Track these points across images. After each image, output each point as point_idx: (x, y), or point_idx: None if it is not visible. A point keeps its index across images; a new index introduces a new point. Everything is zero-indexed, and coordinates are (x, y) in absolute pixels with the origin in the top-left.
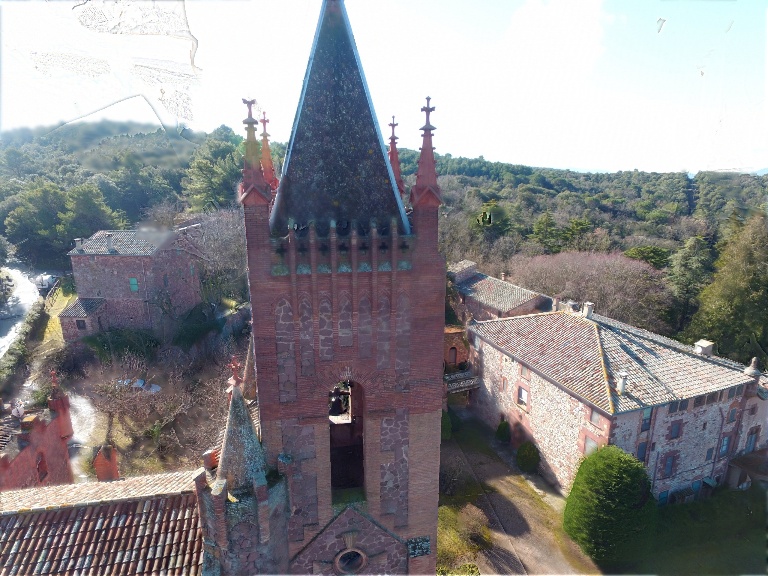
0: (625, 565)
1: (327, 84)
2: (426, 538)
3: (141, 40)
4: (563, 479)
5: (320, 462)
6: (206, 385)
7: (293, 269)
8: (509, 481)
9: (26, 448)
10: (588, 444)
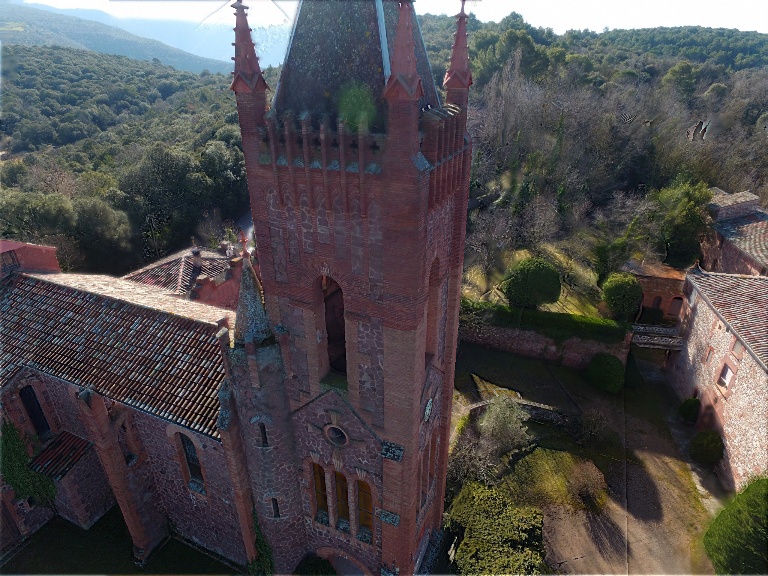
0: None
1: None
2: (400, 447)
3: None
4: (742, 490)
5: (309, 343)
6: None
7: (274, 159)
8: (666, 463)
9: (231, 279)
10: None
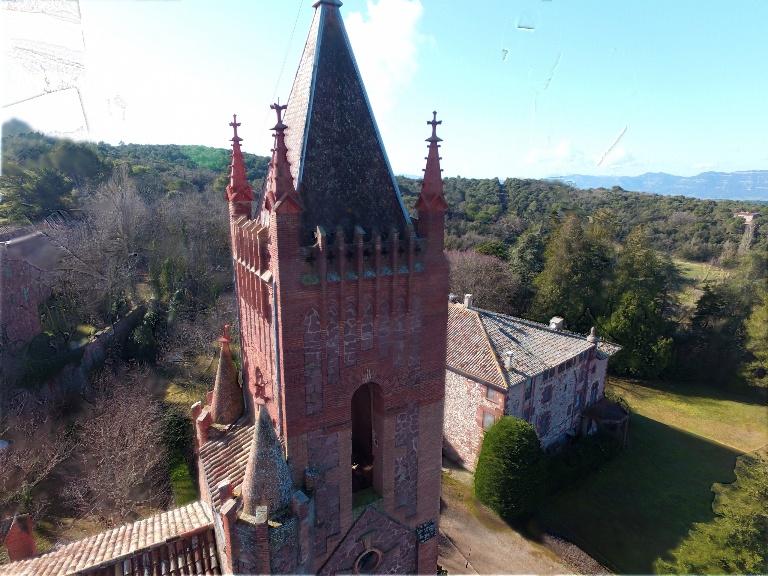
0: (527, 516)
1: (332, 93)
2: (431, 521)
3: (18, 17)
4: (465, 454)
5: (343, 469)
6: (85, 428)
7: (324, 277)
8: None
9: None
10: (486, 418)
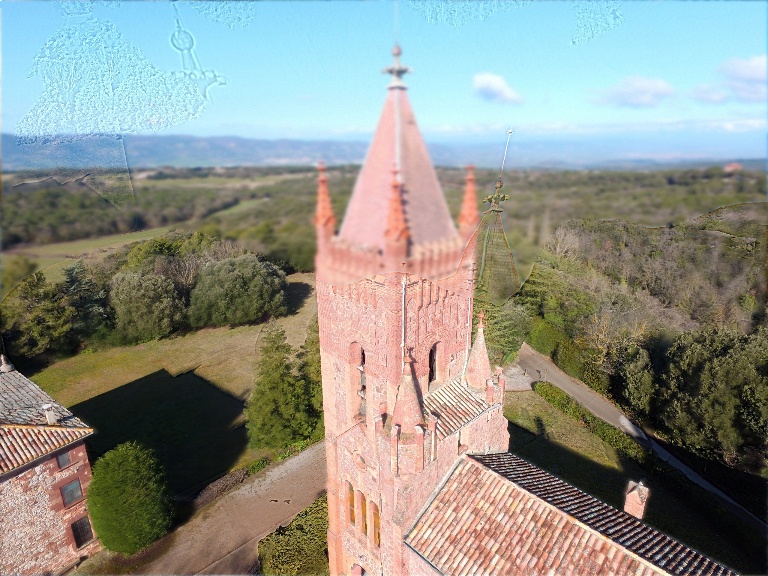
0: None
1: None
2: None
3: None
4: (48, 565)
5: None
6: None
7: None
8: None
9: None
10: (66, 492)
